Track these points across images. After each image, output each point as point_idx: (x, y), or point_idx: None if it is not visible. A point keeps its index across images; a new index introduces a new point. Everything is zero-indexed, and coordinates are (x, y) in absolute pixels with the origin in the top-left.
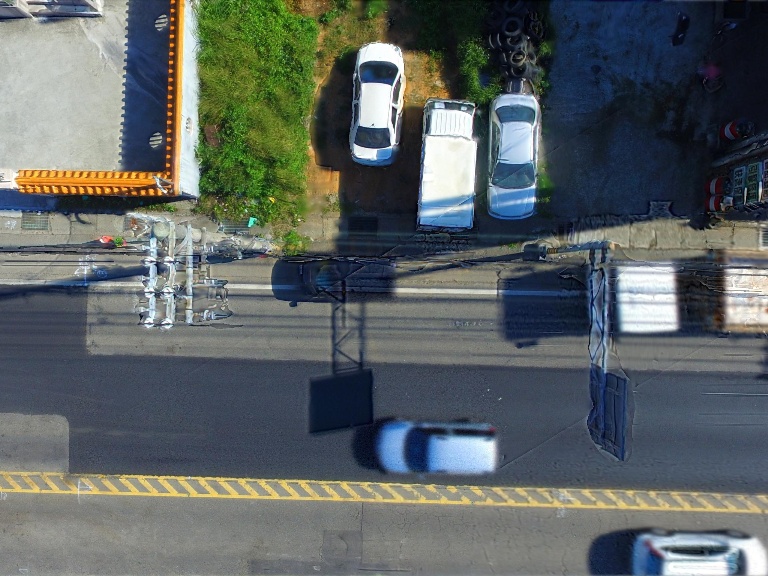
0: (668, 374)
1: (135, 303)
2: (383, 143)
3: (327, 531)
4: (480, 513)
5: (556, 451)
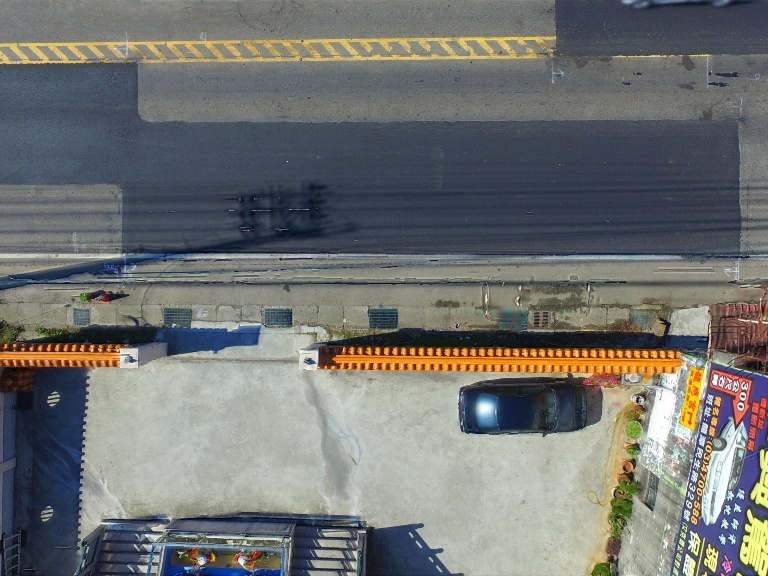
0: None
1: (76, 237)
2: None
3: None
4: None
5: None
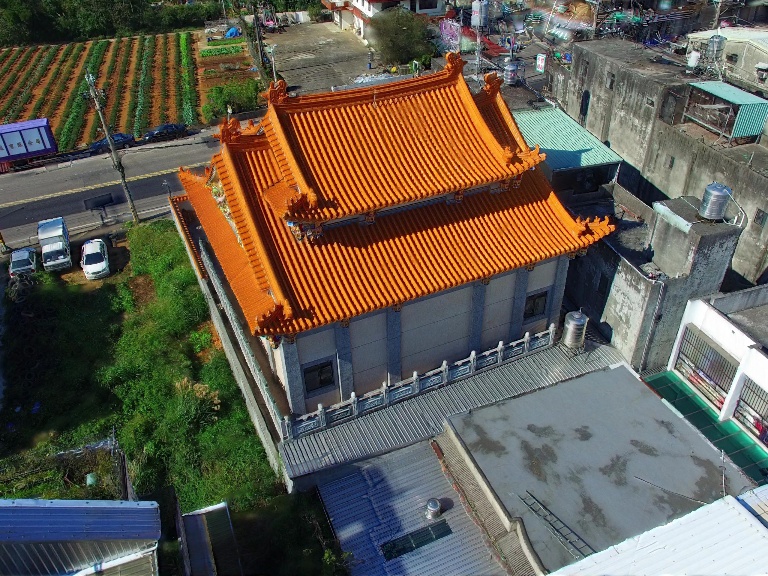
0: None
1: None
2: None
3: None
4: None
5: (1, 214)
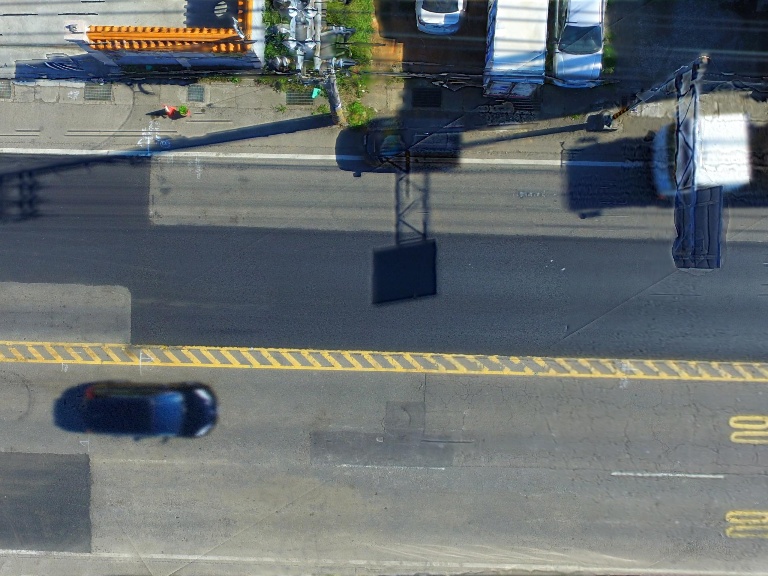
0: (731, 244)
1: (198, 173)
2: (451, 7)
3: (390, 402)
4: (543, 384)
5: (619, 321)
